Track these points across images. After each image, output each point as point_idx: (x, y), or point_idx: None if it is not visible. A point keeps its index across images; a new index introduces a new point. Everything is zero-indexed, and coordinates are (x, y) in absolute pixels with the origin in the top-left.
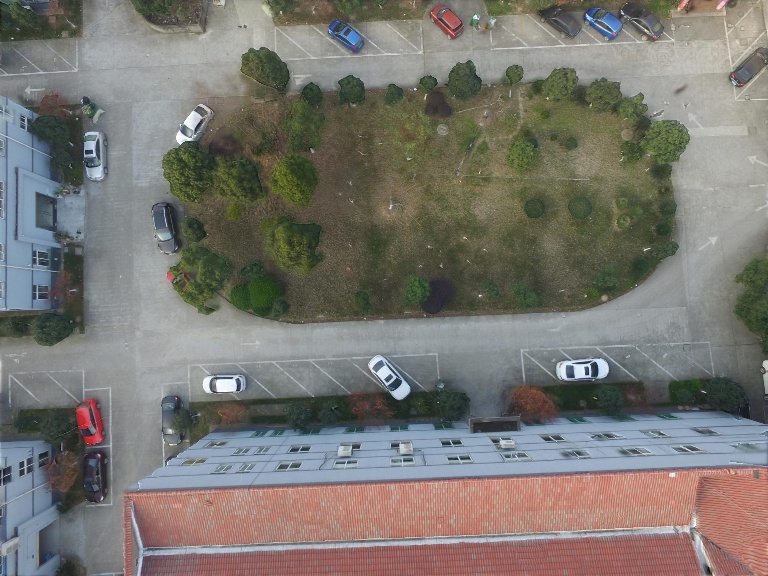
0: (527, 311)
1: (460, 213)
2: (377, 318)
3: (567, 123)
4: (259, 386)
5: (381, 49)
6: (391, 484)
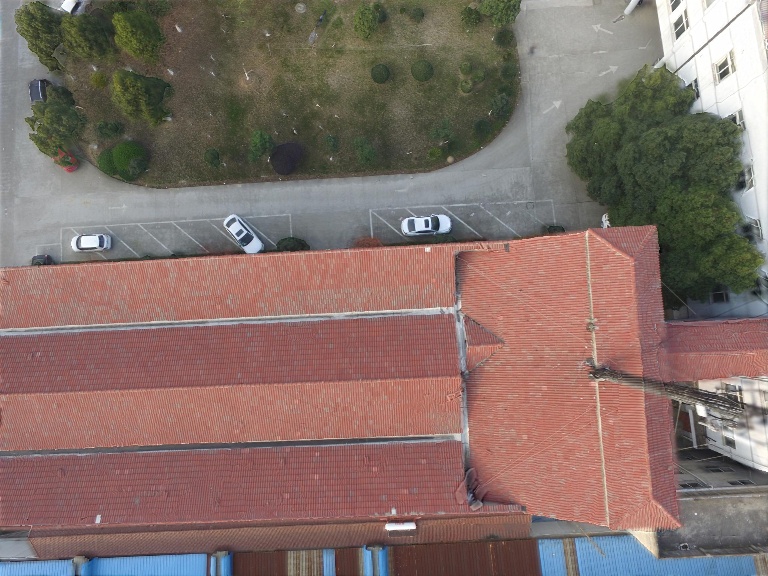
0: (377, 173)
1: (314, 83)
2: (235, 182)
3: None
4: (124, 246)
5: None
6: (166, 260)
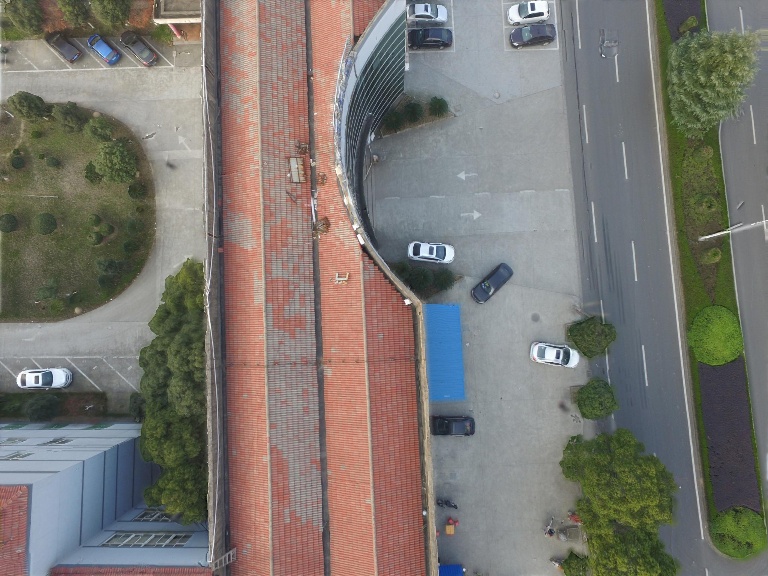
0: (7, 321)
1: None
2: None
3: (61, 143)
4: None
5: None
6: None
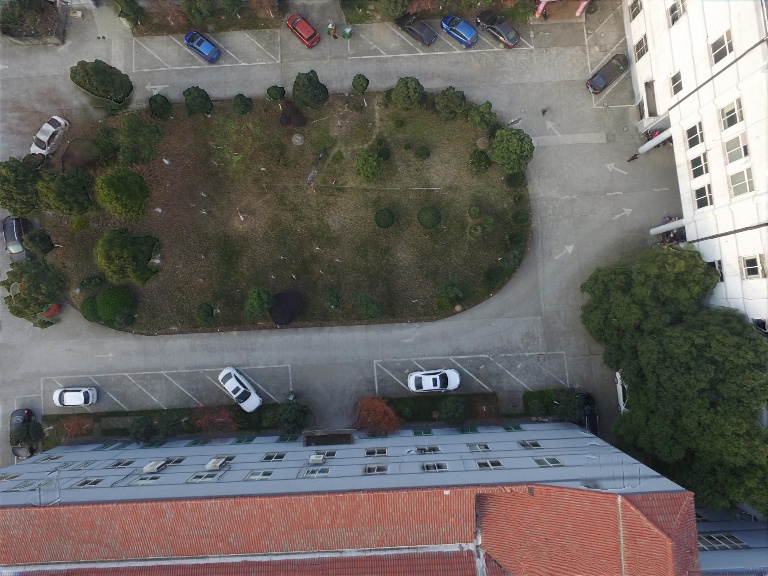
0: (381, 322)
1: (314, 223)
2: (230, 329)
3: (423, 132)
4: (111, 398)
5: (238, 59)
6: (162, 503)
